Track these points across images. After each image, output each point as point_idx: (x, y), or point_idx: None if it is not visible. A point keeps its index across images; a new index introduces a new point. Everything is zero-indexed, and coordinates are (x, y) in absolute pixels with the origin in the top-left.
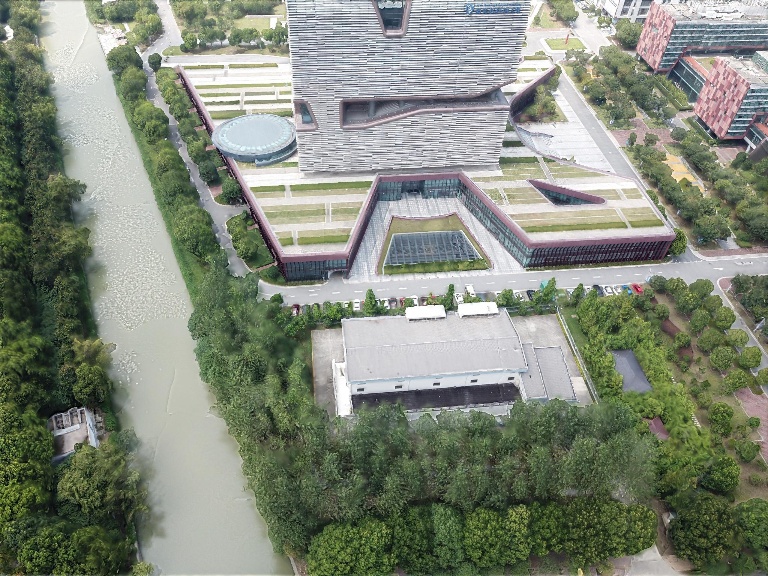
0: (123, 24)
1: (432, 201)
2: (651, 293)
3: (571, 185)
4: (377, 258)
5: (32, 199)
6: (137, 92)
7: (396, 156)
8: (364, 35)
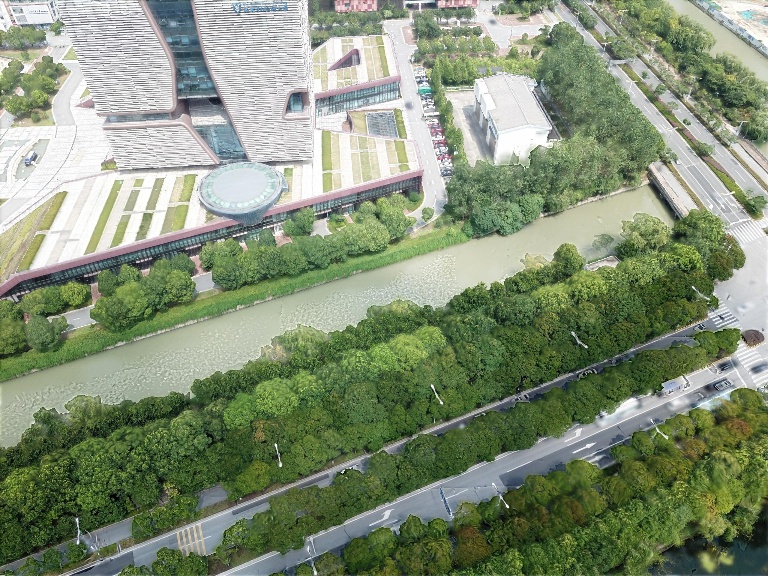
0: None
1: None
2: (429, 57)
3: (336, 58)
4: None
5: None
6: None
7: None
8: None
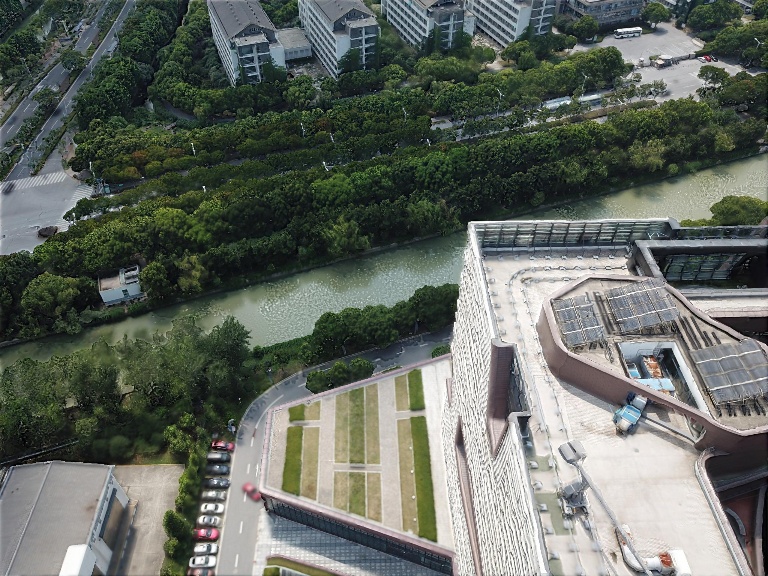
0: None
1: None
2: None
3: None
4: None
5: None
6: None
7: (462, 572)
8: None
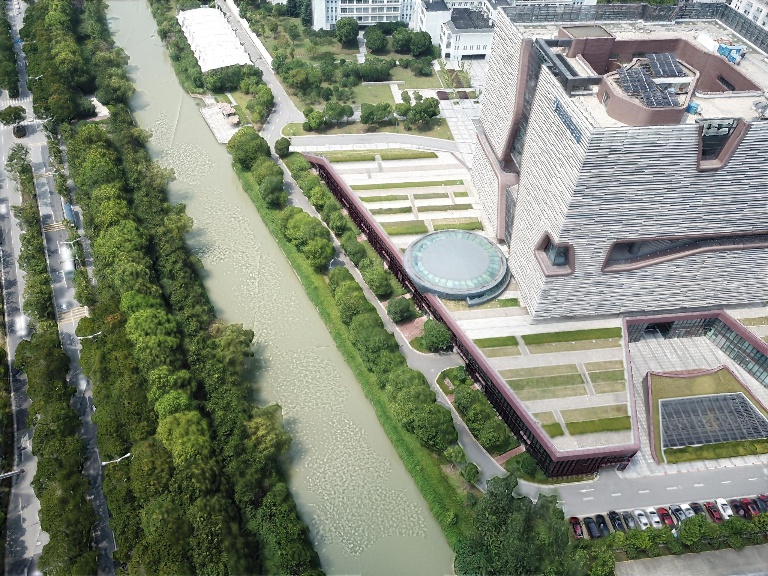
0: (226, 95)
1: (677, 342)
2: None
3: None
4: (646, 435)
5: (198, 360)
6: (278, 192)
7: (654, 297)
8: (672, 169)
